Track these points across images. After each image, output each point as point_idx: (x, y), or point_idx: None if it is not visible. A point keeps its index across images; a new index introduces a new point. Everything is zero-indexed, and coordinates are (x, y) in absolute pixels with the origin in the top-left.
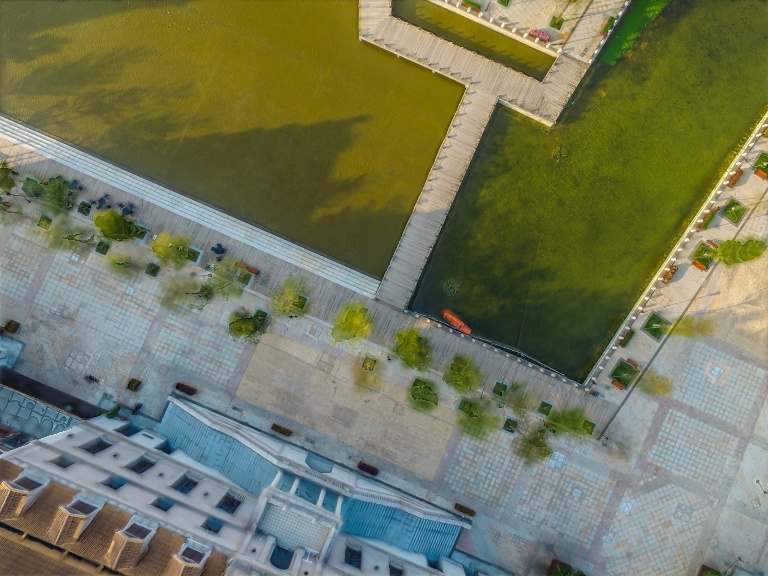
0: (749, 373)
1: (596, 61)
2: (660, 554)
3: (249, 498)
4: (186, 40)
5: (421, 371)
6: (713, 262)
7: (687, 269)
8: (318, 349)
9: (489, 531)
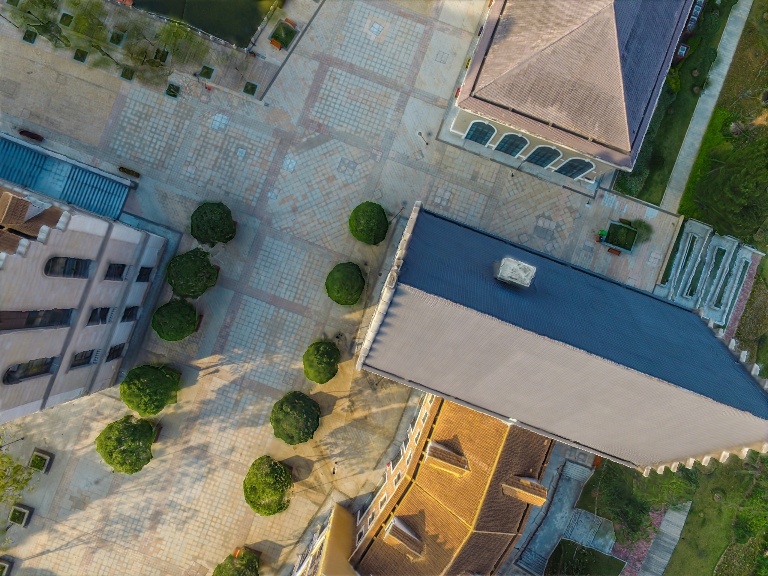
0: (408, 28)
1: None
2: (325, 208)
3: None
4: None
5: (46, 8)
6: None
7: None
8: None
9: (156, 193)
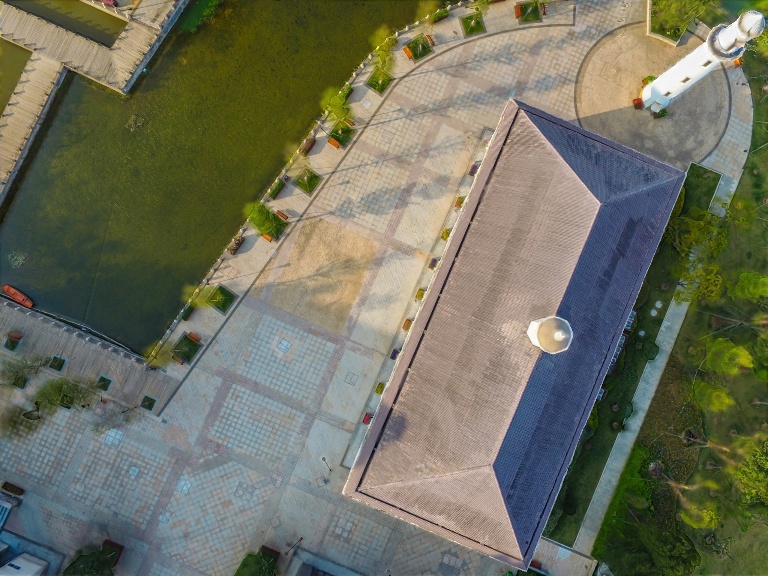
0: (318, 347)
1: (176, 28)
2: (219, 534)
3: None
4: None
5: None
6: (284, 233)
7: (257, 240)
8: None
9: (40, 511)
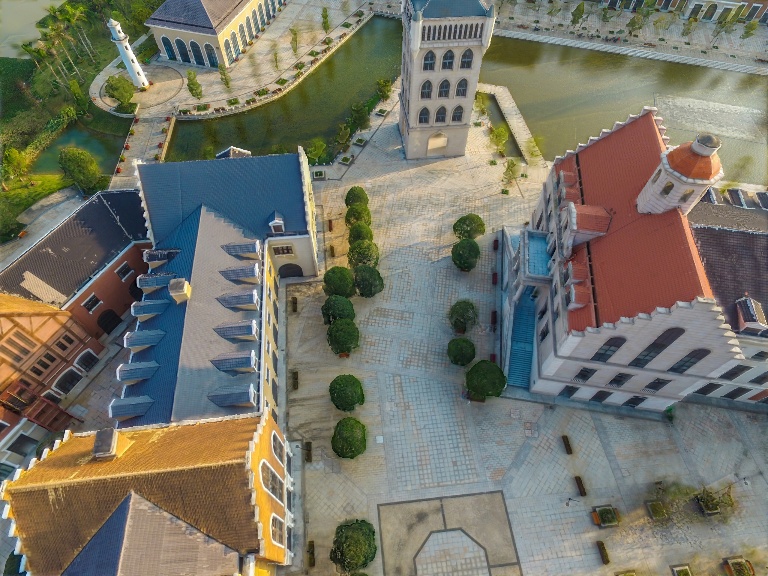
0: None
1: None
2: None
3: None
4: (588, 85)
5: None
6: None
7: None
8: None
9: None
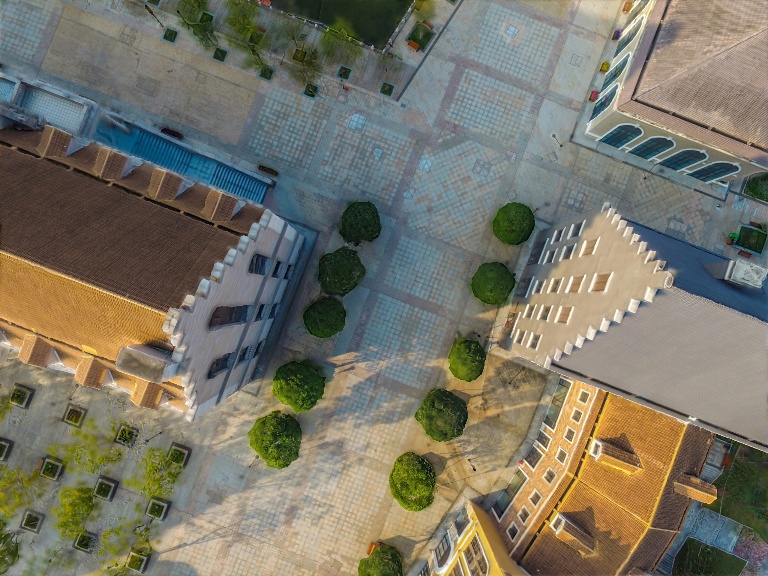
0: (543, 32)
1: None
2: (460, 208)
3: None
4: None
5: (201, 8)
6: None
7: None
8: (120, 23)
9: (293, 191)
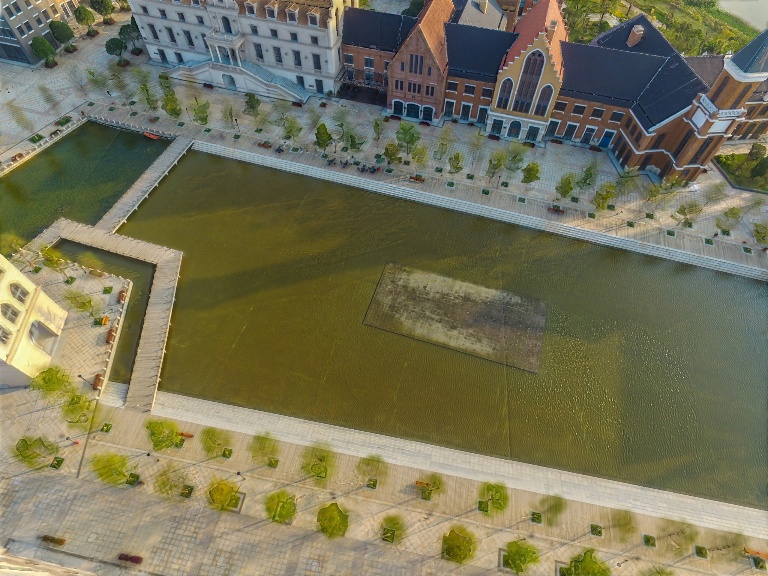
0: None
1: None
2: (72, 71)
3: (255, 61)
4: (303, 246)
5: None
6: None
7: (5, 161)
8: (229, 122)
9: (154, 74)
